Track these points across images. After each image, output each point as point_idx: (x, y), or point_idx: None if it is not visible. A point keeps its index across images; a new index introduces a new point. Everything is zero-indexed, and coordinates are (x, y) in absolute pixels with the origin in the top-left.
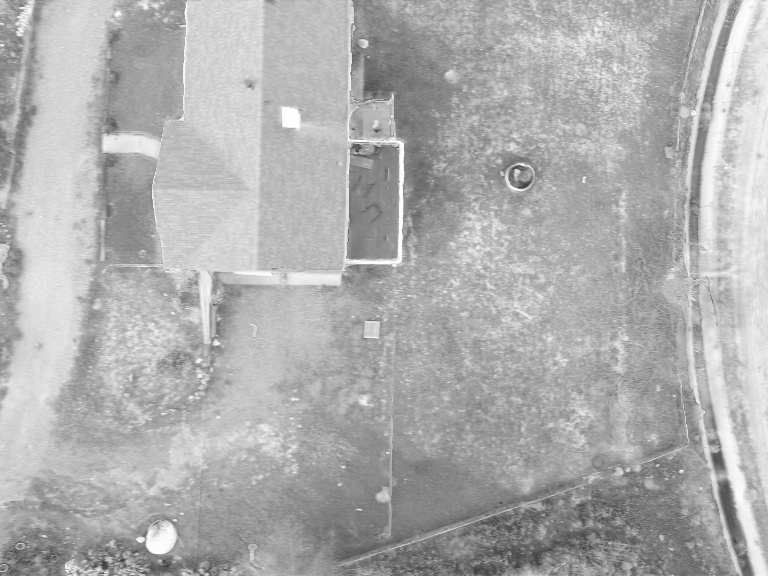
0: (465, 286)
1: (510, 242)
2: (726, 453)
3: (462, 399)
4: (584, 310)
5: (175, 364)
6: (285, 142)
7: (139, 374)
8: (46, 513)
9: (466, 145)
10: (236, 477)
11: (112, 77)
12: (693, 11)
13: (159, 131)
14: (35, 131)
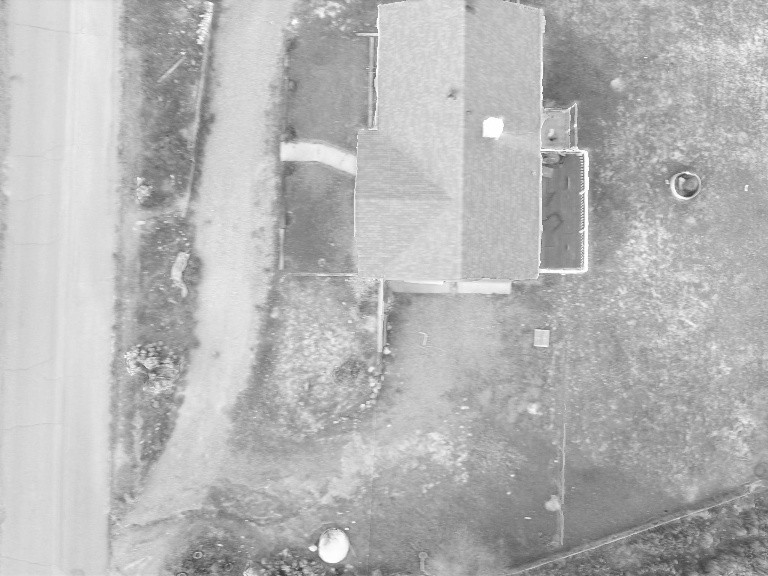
0: (632, 294)
1: (675, 250)
2: None
3: (629, 407)
4: (747, 318)
5: (352, 373)
6: (485, 152)
7: (314, 383)
8: (223, 522)
9: (632, 153)
10: (407, 486)
11: (292, 85)
12: None
13: (338, 139)
14: (213, 139)
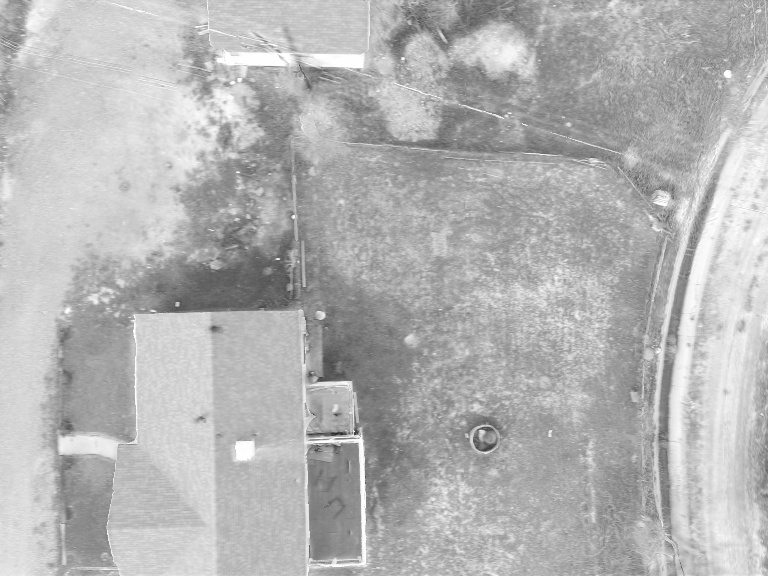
0: (434, 553)
1: (478, 504)
2: None
3: None
4: (555, 565)
5: None
6: (240, 471)
7: None
8: None
9: (429, 409)
10: None
11: (65, 380)
12: (654, 249)
13: (115, 431)
14: None
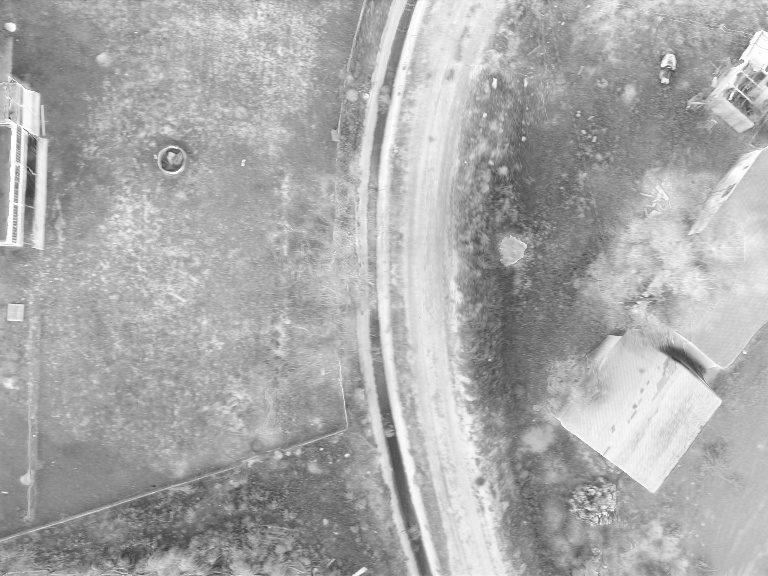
0: (115, 269)
1: (163, 225)
2: (400, 437)
3: (112, 382)
4: (242, 293)
5: None
6: None
7: None
8: None
9: (118, 128)
10: None
11: None
12: None
13: None
14: None
